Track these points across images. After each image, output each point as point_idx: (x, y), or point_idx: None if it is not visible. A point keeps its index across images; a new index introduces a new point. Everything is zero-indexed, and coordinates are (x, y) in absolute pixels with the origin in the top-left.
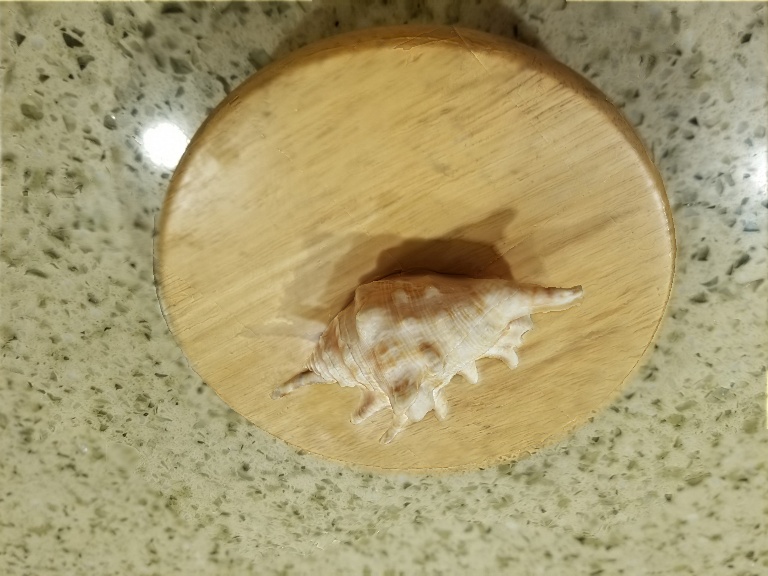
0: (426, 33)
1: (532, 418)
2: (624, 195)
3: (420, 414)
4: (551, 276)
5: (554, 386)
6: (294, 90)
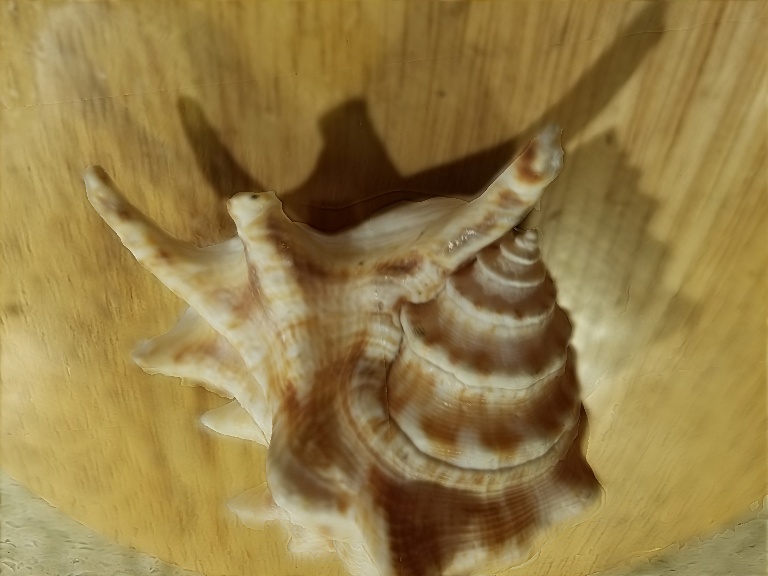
0: None
1: (7, 394)
2: None
3: (309, 526)
4: None
5: (91, 447)
6: None
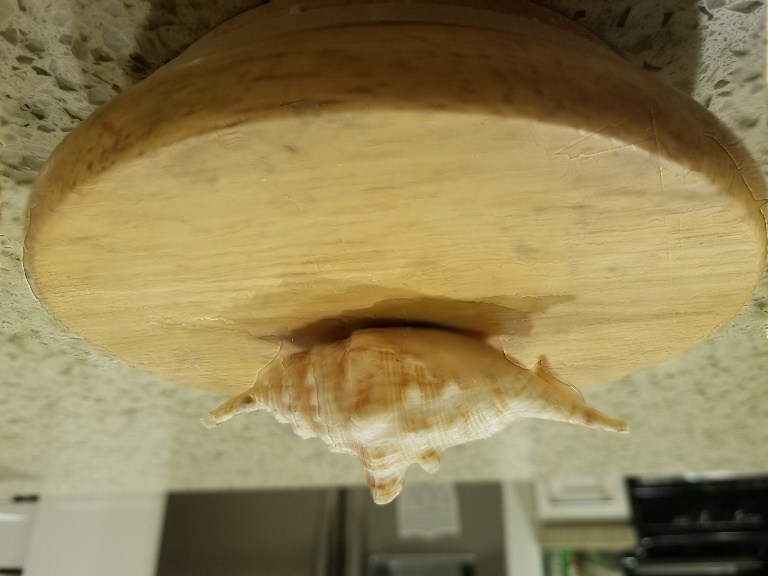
0: (611, 127)
1: None
2: (707, 304)
3: None
4: (571, 334)
5: None
6: (348, 143)
